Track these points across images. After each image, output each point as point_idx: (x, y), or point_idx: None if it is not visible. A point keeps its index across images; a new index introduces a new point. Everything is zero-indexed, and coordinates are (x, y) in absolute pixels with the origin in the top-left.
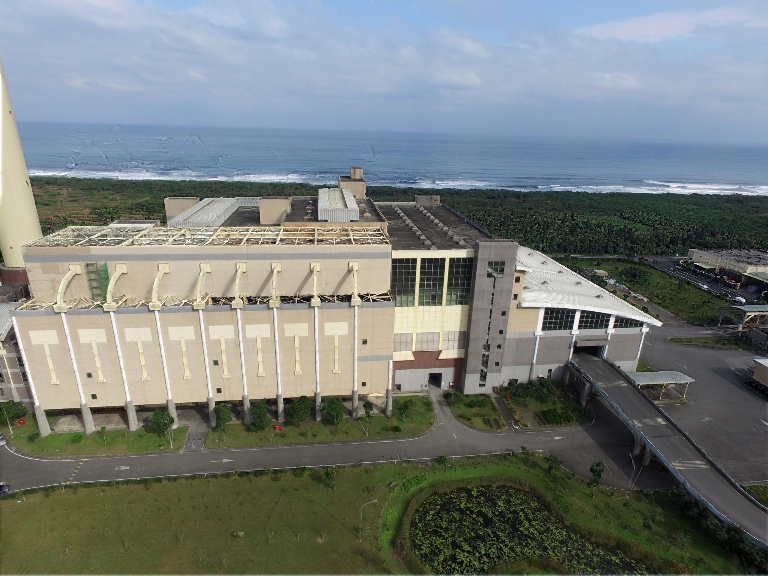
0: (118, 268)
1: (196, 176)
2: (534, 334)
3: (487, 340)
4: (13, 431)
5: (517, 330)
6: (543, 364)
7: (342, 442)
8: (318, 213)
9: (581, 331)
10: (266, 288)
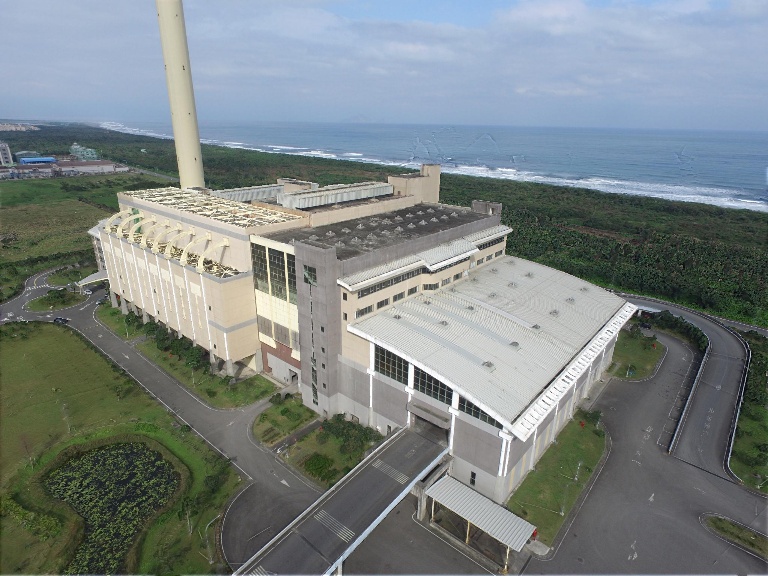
0: None
1: (492, 173)
2: (367, 371)
3: (313, 353)
4: None
5: (351, 358)
6: (381, 414)
7: (178, 382)
8: (277, 197)
9: (418, 393)
10: None
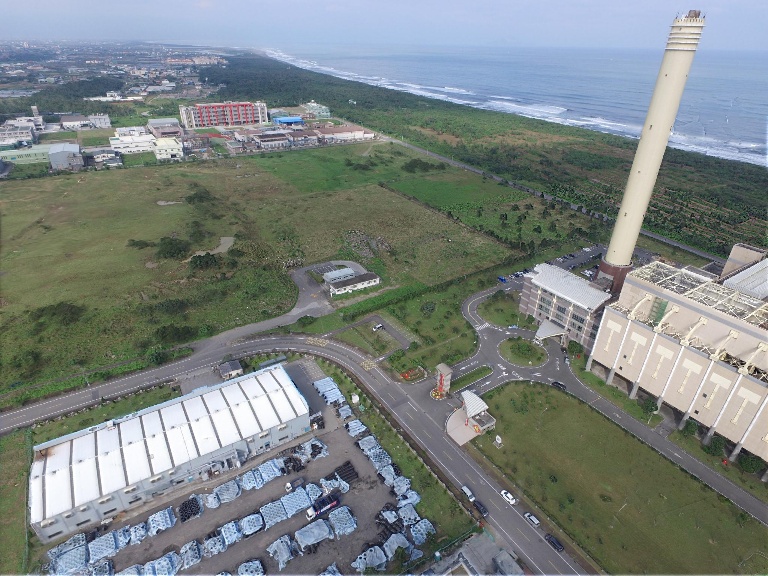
0: (674, 308)
1: None
2: None
3: None
4: (574, 359)
5: None
6: None
7: None
8: None
9: None
10: None
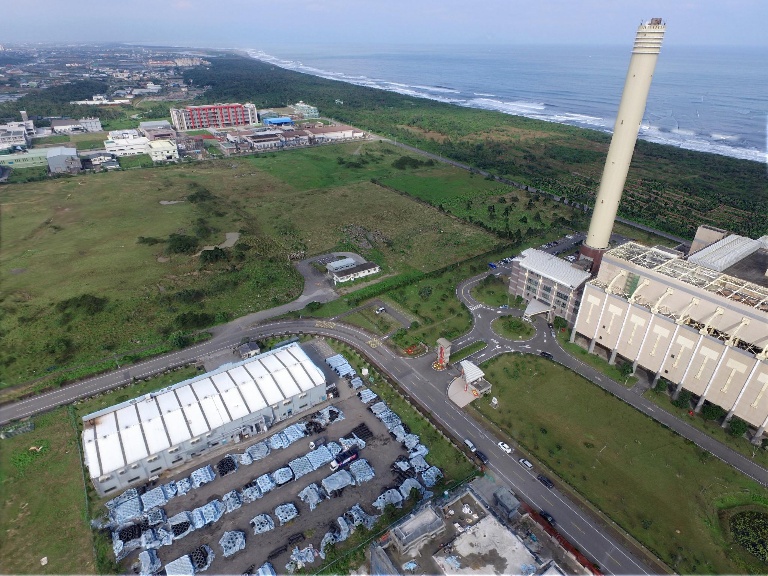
0: (645, 281)
1: (762, 157)
2: None
3: None
4: (559, 332)
5: None
6: None
7: (730, 448)
8: None
9: None
10: (731, 330)
